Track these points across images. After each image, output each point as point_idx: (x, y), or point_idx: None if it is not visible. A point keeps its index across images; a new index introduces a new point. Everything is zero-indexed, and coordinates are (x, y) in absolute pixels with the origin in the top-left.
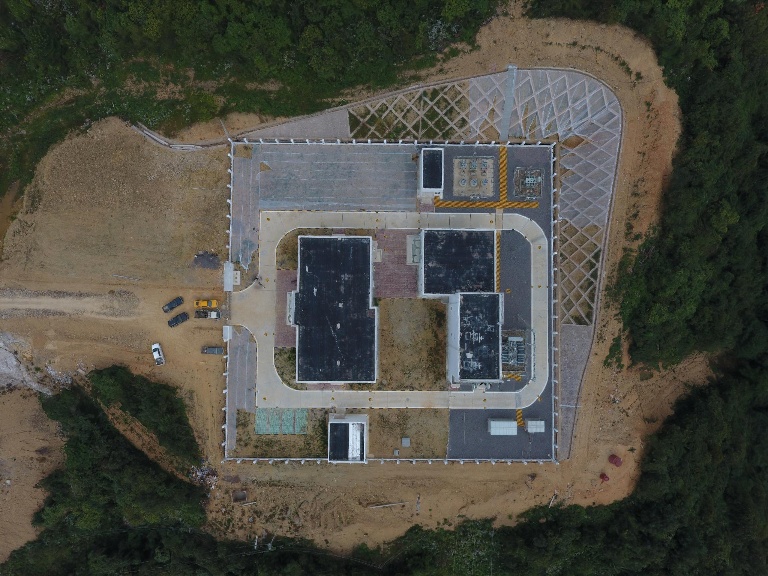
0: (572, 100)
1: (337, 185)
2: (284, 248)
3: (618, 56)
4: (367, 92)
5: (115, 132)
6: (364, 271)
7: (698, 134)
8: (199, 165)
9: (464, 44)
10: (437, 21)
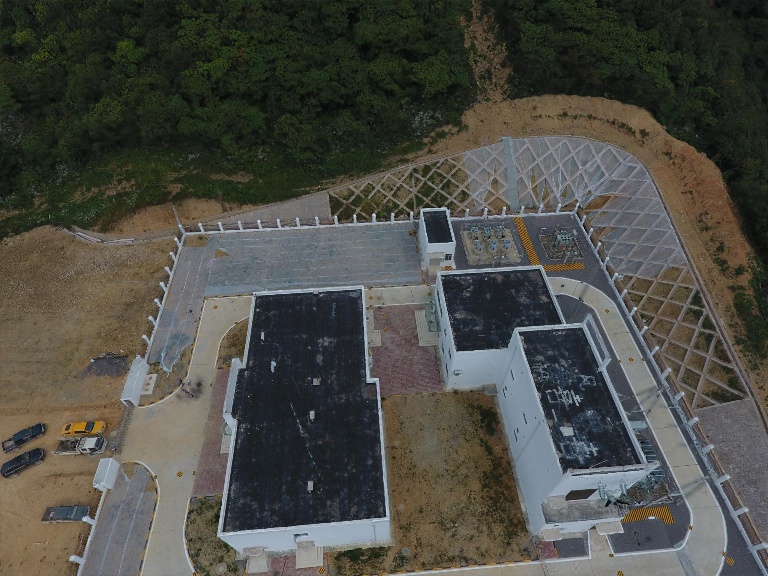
0: (581, 163)
1: (315, 264)
2: (233, 339)
3: (614, 120)
4: (350, 179)
5: (39, 237)
6: (355, 331)
7: (743, 162)
8: (135, 259)
9: (450, 127)
10: (419, 113)
